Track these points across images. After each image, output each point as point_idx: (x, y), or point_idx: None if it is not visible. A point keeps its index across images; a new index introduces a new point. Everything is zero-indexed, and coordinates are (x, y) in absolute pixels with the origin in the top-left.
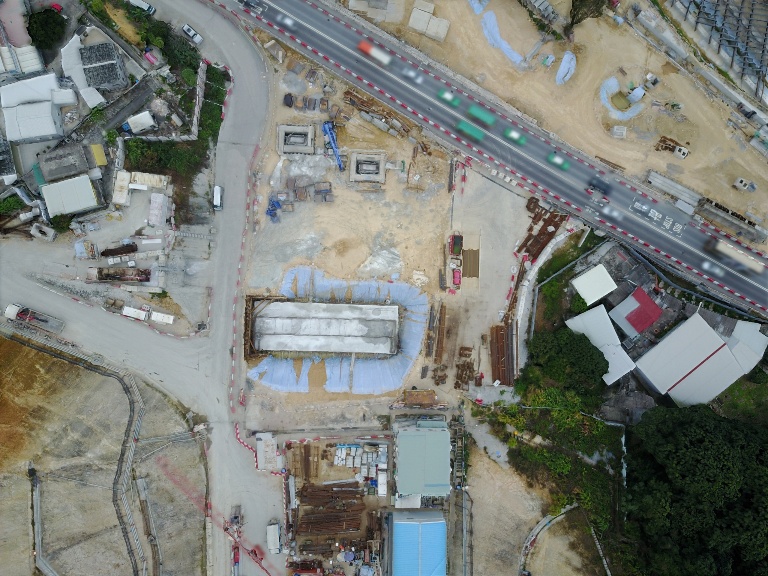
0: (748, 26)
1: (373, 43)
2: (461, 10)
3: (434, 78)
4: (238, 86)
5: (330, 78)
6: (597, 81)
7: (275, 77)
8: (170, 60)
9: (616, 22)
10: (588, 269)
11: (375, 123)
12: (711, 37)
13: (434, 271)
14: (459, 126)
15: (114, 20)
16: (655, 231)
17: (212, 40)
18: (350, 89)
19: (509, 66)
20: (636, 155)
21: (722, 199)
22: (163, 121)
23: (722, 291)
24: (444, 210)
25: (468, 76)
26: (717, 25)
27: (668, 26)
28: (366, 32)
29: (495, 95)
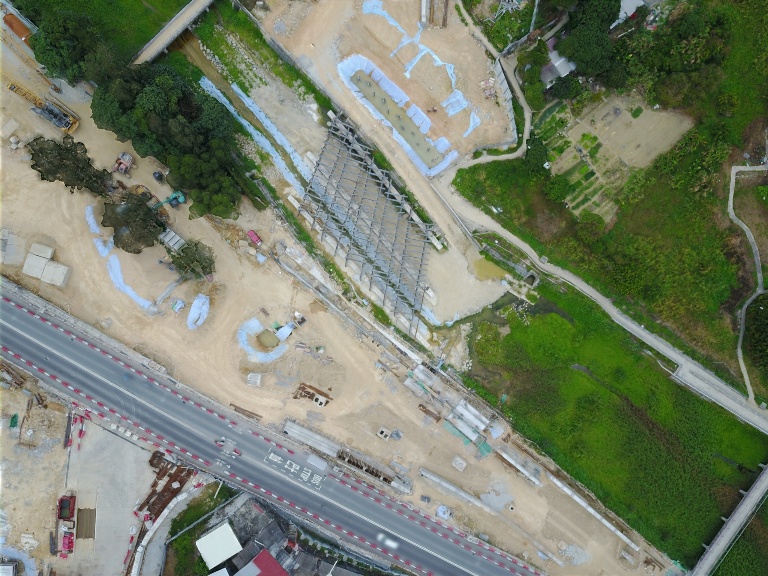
0: (402, 262)
1: None
2: (86, 252)
3: (52, 326)
4: None
5: None
6: (235, 323)
7: None
8: None
9: (257, 261)
10: (220, 524)
11: None
12: (362, 274)
13: (44, 534)
14: (79, 376)
15: None
16: (292, 484)
17: None
18: None
19: (138, 310)
20: (273, 403)
21: (366, 448)
22: None
23: (364, 546)
24: (58, 467)
25: (92, 321)
26: (372, 259)
27: (315, 263)
28: None
29: (118, 343)
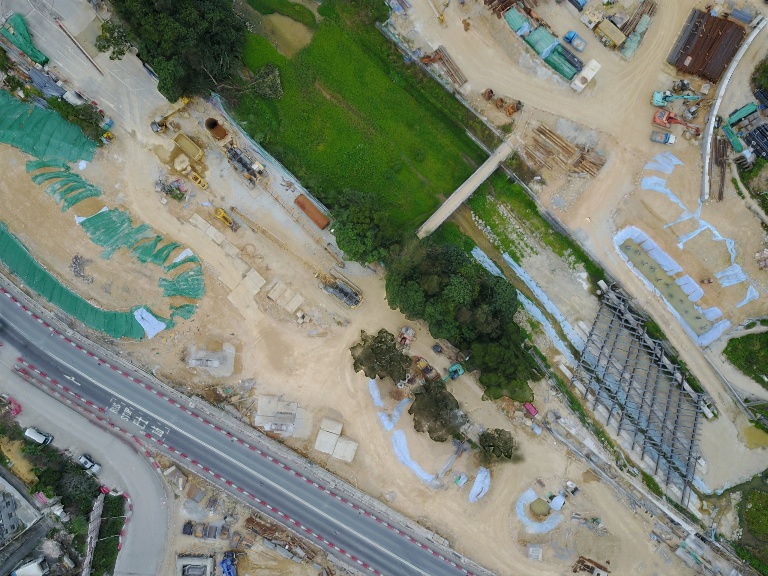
0: (673, 431)
1: (278, 465)
2: (371, 425)
3: (341, 500)
4: (137, 512)
5: (232, 503)
6: (513, 495)
7: (175, 504)
8: (63, 503)
9: (534, 432)
10: None
11: (278, 552)
12: (634, 443)
13: None
14: (366, 550)
15: (8, 456)
16: None
17: (111, 465)
18: (253, 514)
19: (420, 483)
20: (553, 575)
21: None
22: (55, 563)
23: None
24: None
25: (377, 494)
26: (641, 427)
27: (589, 433)
28: (271, 453)
29: (404, 517)
